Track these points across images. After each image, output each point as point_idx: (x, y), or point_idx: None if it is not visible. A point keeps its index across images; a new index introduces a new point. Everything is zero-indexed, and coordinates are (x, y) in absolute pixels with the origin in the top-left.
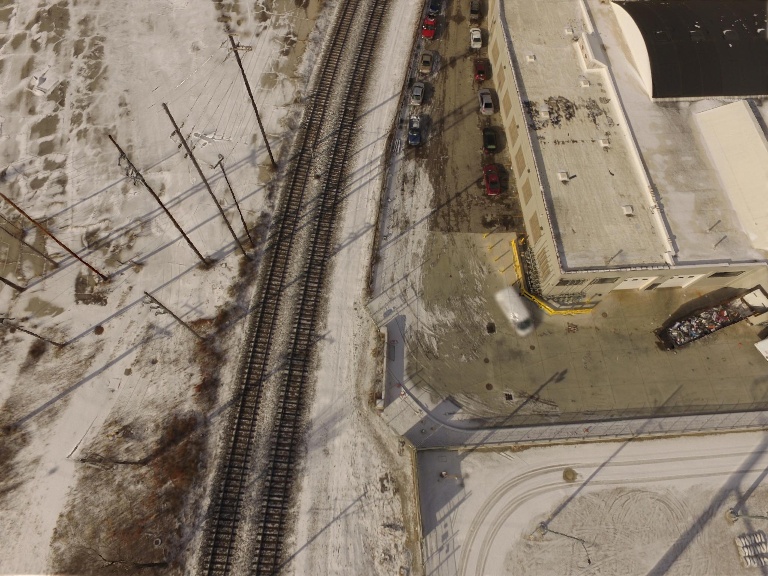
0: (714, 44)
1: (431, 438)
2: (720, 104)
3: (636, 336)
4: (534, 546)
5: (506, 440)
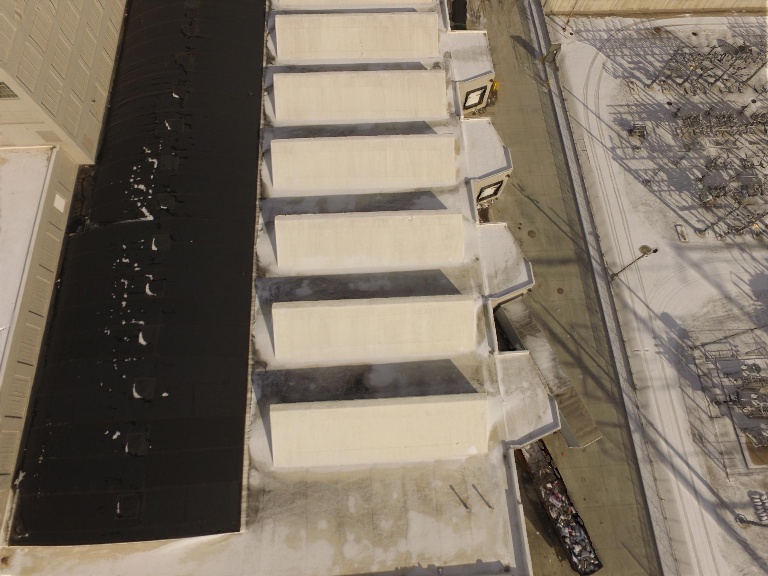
0: (159, 421)
1: None
2: (259, 423)
3: None
4: None
5: None
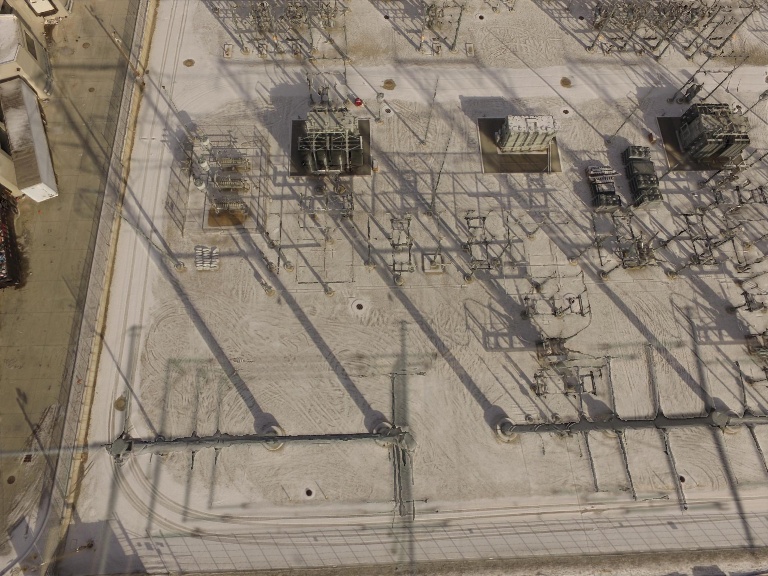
0: None
1: (45, 559)
2: None
3: (3, 307)
4: (173, 452)
5: (68, 470)
